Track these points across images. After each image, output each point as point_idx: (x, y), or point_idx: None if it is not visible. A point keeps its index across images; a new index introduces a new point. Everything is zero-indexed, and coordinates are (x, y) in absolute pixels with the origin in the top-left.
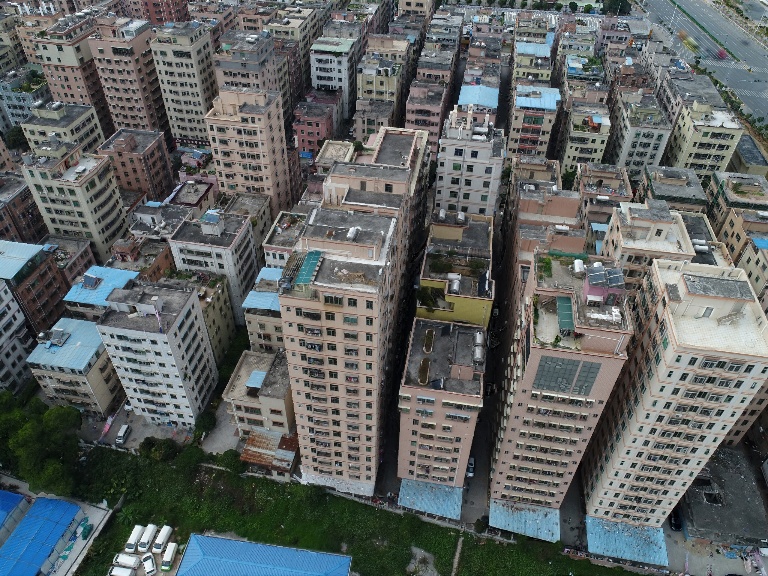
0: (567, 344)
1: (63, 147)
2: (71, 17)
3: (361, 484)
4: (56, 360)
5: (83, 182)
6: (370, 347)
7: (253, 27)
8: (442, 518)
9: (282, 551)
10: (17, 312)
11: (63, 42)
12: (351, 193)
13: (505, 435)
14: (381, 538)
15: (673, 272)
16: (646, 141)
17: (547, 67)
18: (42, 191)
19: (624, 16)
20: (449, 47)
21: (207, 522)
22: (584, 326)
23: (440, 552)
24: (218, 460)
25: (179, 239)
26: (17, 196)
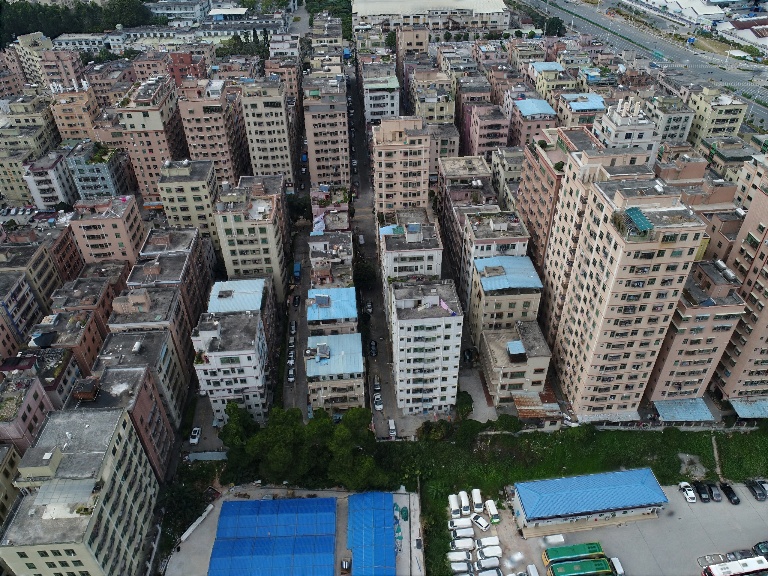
0: None
1: (245, 191)
2: (146, 85)
3: (627, 413)
4: (334, 369)
5: None
6: (683, 275)
7: None
8: (697, 424)
9: (595, 477)
10: (264, 340)
11: (150, 108)
12: (606, 169)
13: (753, 336)
14: (651, 454)
15: None
16: (676, 124)
17: (569, 79)
18: (231, 234)
19: (567, 37)
20: (473, 74)
21: (503, 480)
22: None
23: (703, 451)
24: (496, 425)
25: (390, 250)
26: (193, 246)
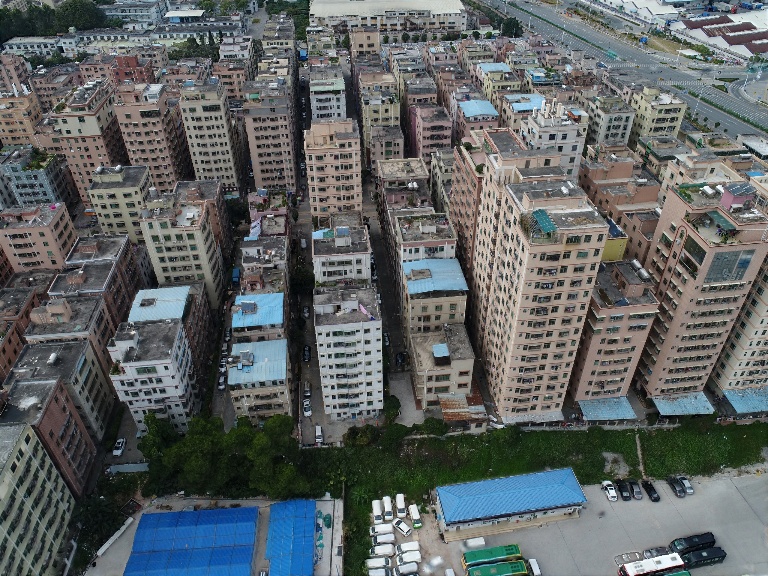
0: (727, 242)
1: (172, 197)
2: (83, 90)
3: (551, 413)
4: (256, 377)
5: (200, 225)
6: (591, 276)
7: (229, 82)
8: (620, 422)
9: (516, 479)
10: (188, 349)
11: (85, 113)
12: (520, 171)
13: (669, 334)
14: (576, 454)
15: (764, 184)
16: (617, 124)
17: (515, 79)
18: (159, 241)
19: (523, 37)
20: (421, 75)
21: (428, 483)
22: (743, 223)
23: (626, 449)
24: (422, 428)
25: None
26: (121, 254)
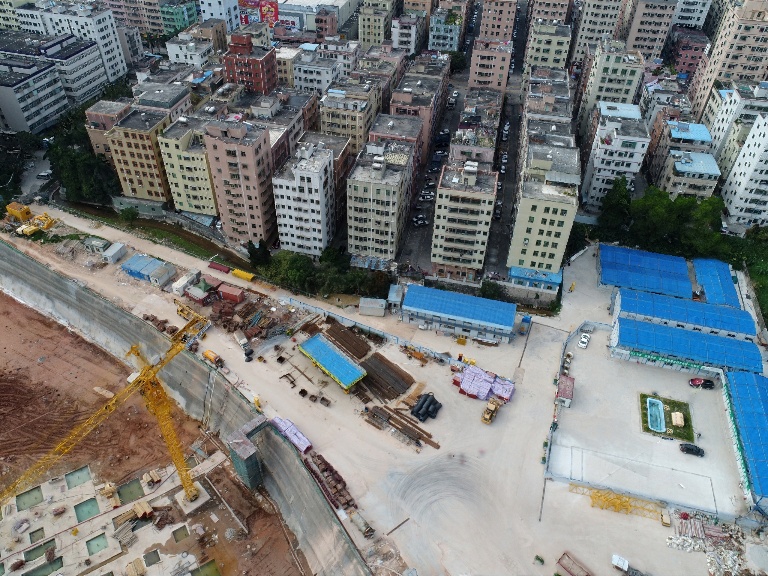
0: None
1: None
2: None
3: None
4: (697, 170)
5: None
6: None
7: None
8: None
9: None
10: None
11: None
12: None
13: None
14: None
15: None
16: None
17: None
18: (607, 73)
19: None
20: None
21: None
22: None
23: None
24: None
25: None
26: None
